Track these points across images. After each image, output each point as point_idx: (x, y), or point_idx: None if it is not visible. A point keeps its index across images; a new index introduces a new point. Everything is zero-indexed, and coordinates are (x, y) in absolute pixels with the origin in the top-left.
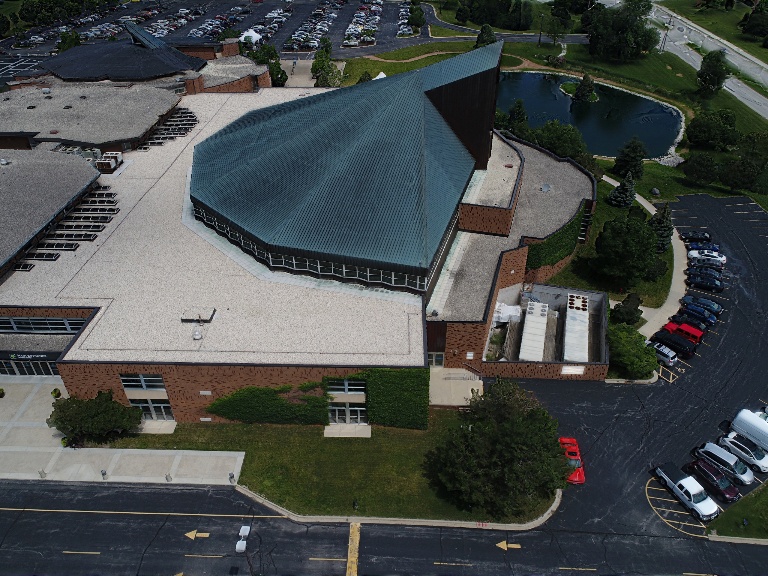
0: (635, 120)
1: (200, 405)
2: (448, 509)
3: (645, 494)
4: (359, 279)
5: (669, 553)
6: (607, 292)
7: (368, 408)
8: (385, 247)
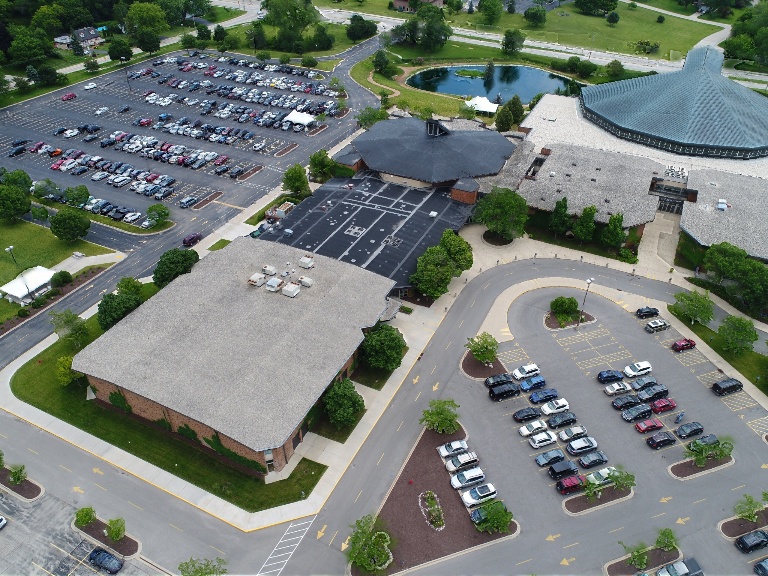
0: (519, 78)
1: None
2: None
3: None
4: None
5: None
6: None
7: None
8: None
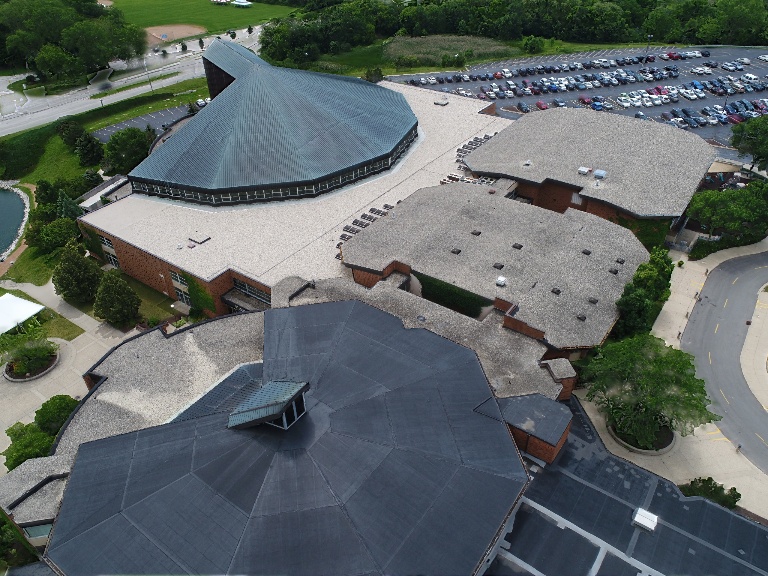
0: None
1: None
2: None
3: None
4: None
5: None
6: None
7: None
8: None
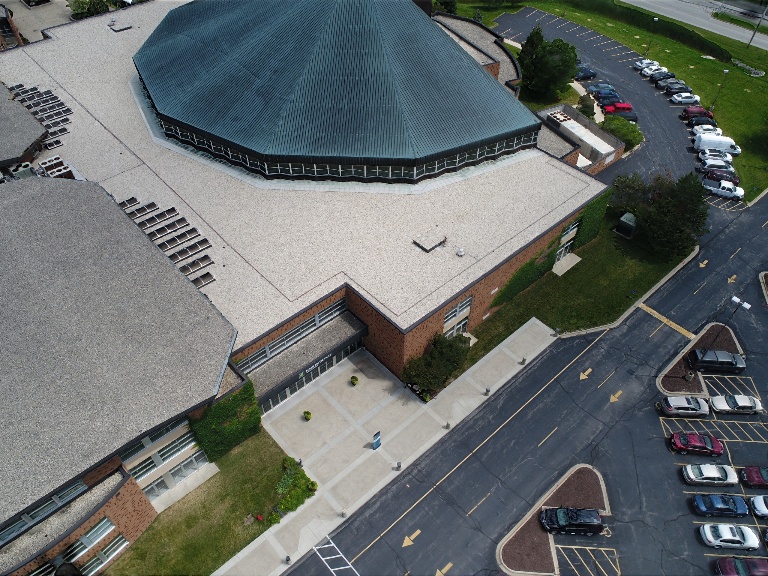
0: None
1: (487, 305)
2: (664, 266)
3: (709, 203)
4: (487, 156)
5: (748, 222)
6: (552, 104)
7: (576, 239)
8: (501, 120)
